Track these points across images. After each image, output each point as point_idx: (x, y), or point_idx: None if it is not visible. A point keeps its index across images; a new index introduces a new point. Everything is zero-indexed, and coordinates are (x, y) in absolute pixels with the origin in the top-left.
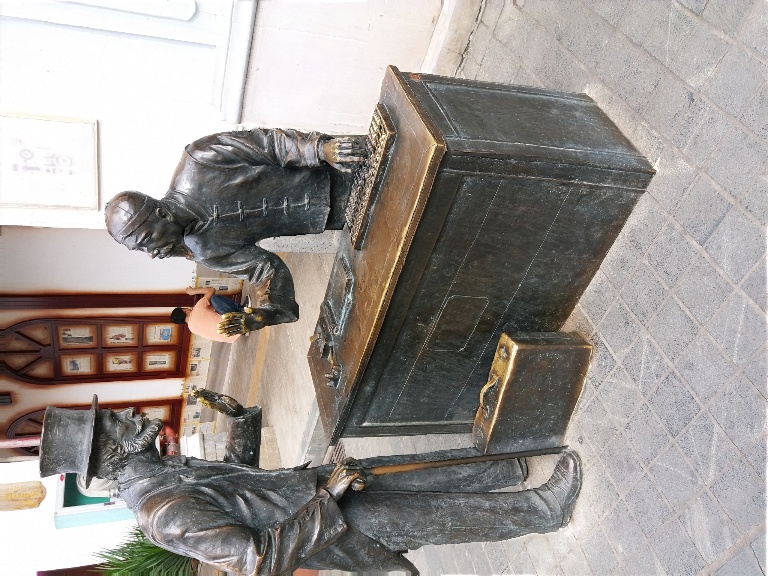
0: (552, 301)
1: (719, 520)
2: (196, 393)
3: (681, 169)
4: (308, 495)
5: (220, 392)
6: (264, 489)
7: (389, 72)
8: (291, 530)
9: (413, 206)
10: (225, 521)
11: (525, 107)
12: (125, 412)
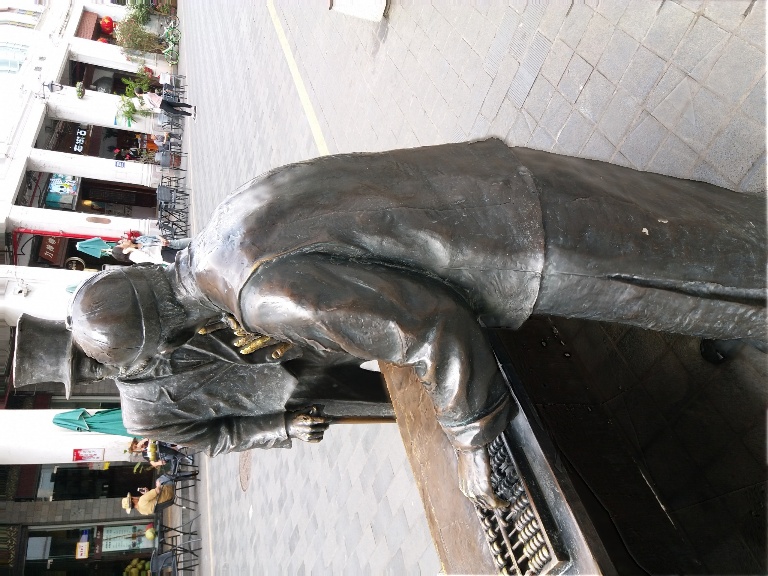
0: (607, 461)
1: None
2: None
3: None
4: (277, 405)
5: None
6: (240, 394)
7: None
8: (245, 444)
9: None
10: (191, 436)
11: None
12: None
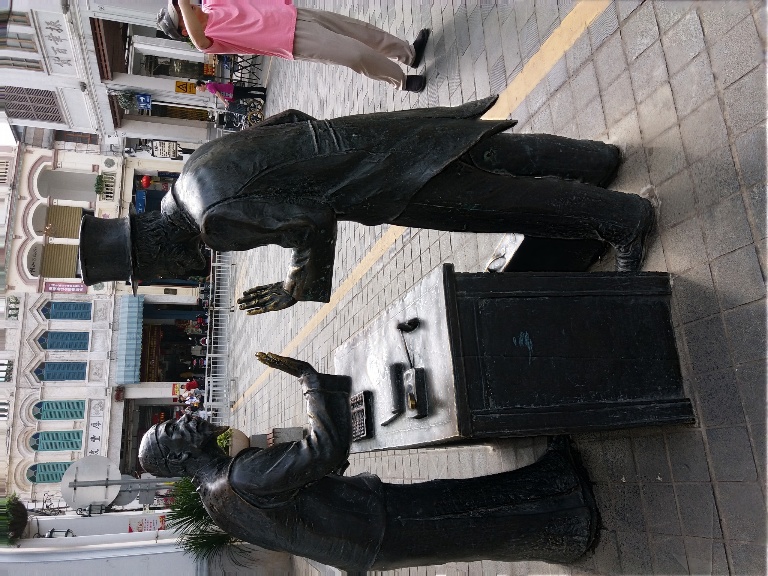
0: None
1: None
2: (241, 300)
3: None
4: None
5: None
6: None
7: None
8: None
9: (344, 345)
10: None
11: None
12: None
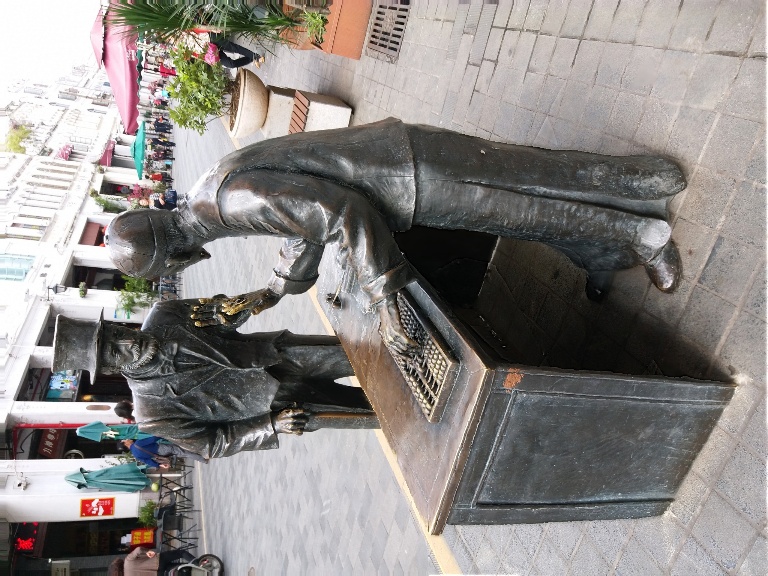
0: None
1: (492, 571)
2: (194, 317)
3: (667, 549)
4: (263, 406)
5: (220, 300)
6: (232, 395)
7: (478, 383)
8: (238, 443)
9: None
10: (192, 433)
11: (614, 430)
12: (125, 344)
